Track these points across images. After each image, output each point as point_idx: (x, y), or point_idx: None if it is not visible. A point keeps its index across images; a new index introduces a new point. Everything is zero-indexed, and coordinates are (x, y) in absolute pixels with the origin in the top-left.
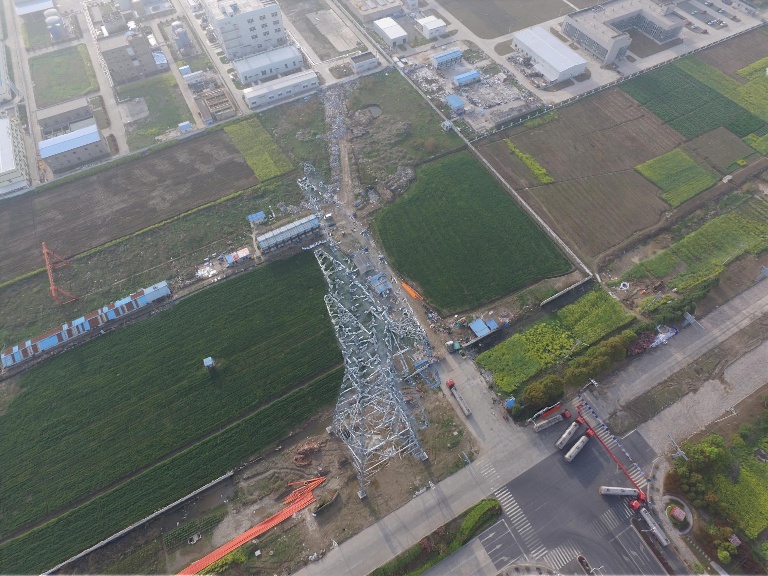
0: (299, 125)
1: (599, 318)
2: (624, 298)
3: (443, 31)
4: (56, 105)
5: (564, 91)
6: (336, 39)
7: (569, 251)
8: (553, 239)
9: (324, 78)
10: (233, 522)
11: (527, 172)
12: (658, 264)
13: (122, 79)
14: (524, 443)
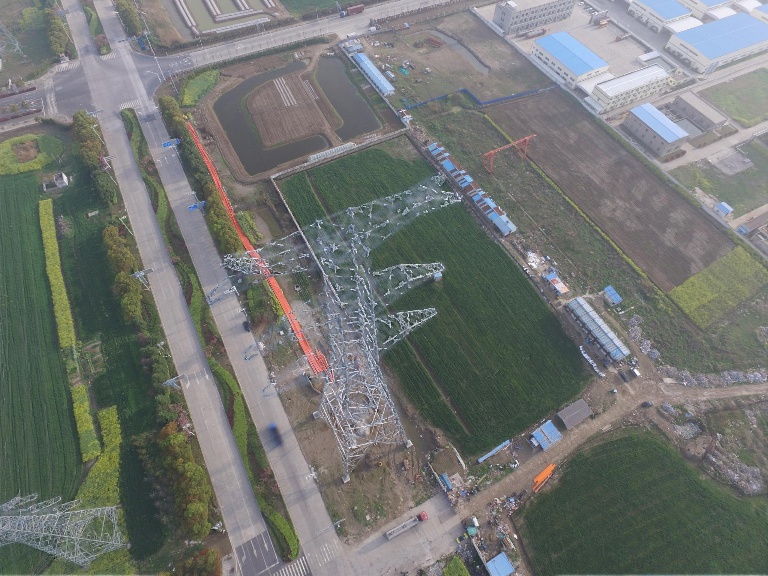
0: None
1: None
2: None
3: None
4: (705, 102)
5: None
6: None
7: None
8: None
9: None
10: None
11: None
12: None
13: None
14: None
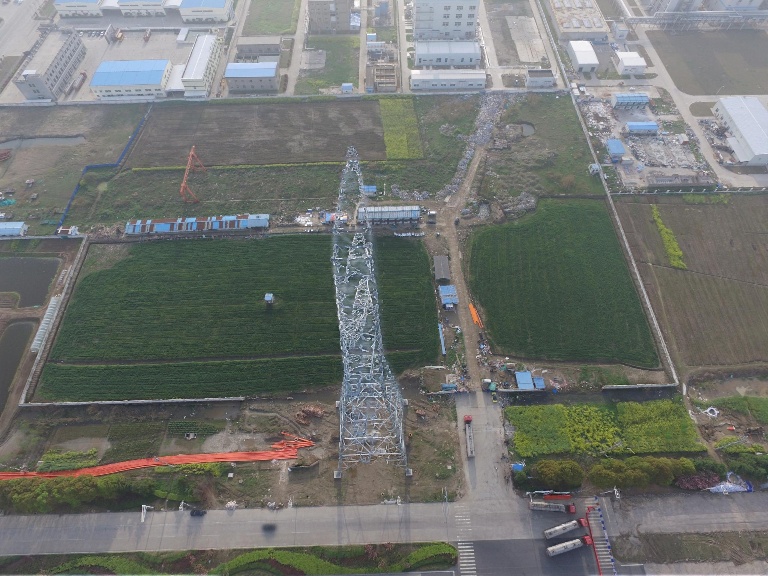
0: (447, 119)
1: (662, 431)
2: (704, 424)
3: (640, 71)
4: (256, 36)
5: (751, 177)
6: (524, 48)
7: (664, 347)
8: (652, 327)
9: (493, 82)
10: (225, 439)
11: (659, 247)
12: (767, 407)
13: (317, 30)
14: (513, 512)
